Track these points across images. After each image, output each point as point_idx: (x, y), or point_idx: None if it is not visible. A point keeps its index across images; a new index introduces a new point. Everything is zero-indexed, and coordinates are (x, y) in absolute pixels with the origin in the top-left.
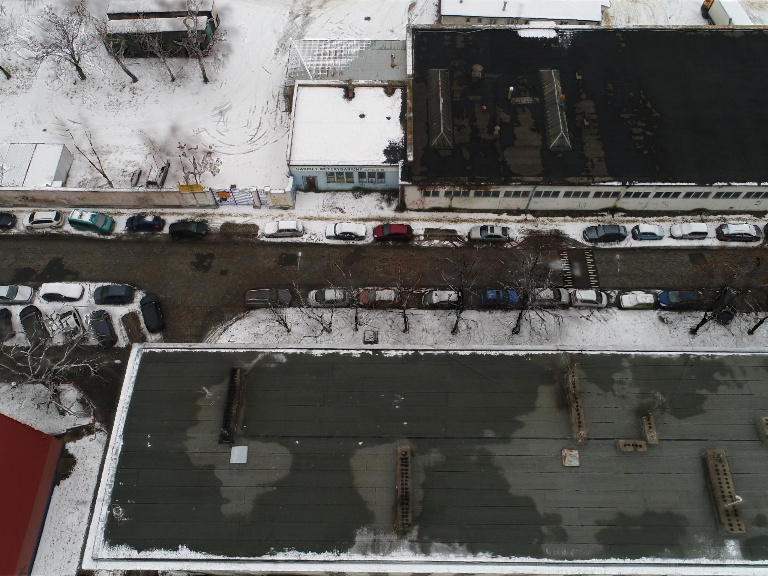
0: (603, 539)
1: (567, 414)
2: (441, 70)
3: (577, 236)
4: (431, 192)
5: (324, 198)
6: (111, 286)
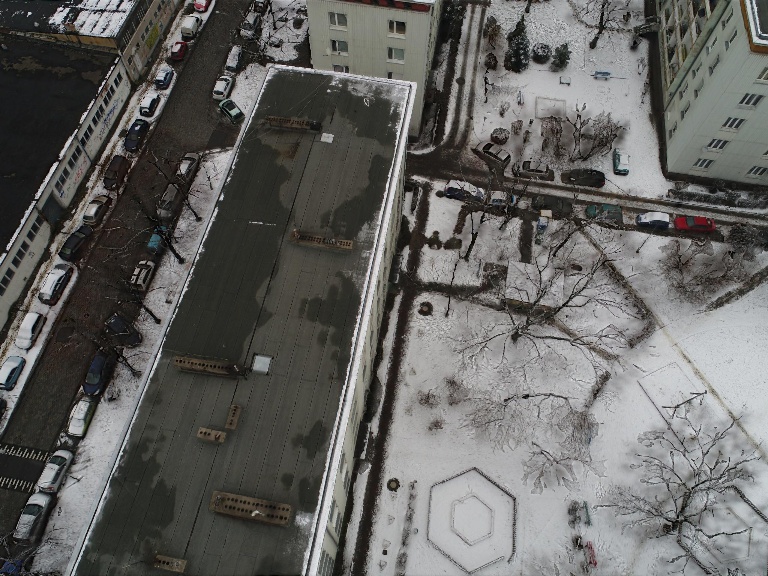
0: None
1: None
2: None
3: None
4: None
5: None
6: None
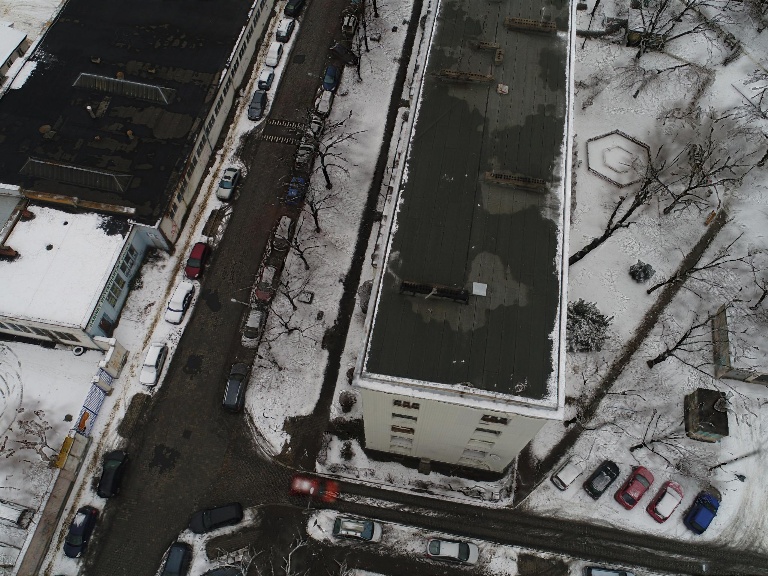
0: (554, 88)
1: (471, 85)
2: (30, 159)
3: (252, 125)
4: (172, 210)
5: (128, 319)
6: (166, 568)
